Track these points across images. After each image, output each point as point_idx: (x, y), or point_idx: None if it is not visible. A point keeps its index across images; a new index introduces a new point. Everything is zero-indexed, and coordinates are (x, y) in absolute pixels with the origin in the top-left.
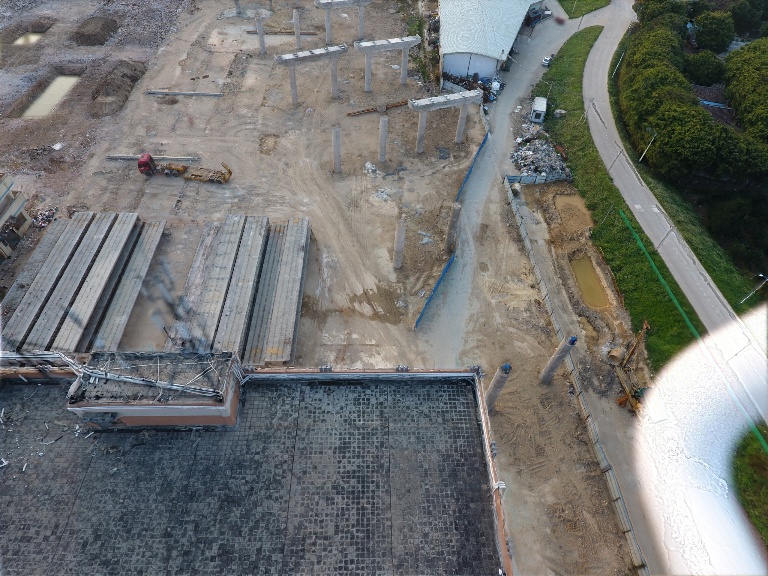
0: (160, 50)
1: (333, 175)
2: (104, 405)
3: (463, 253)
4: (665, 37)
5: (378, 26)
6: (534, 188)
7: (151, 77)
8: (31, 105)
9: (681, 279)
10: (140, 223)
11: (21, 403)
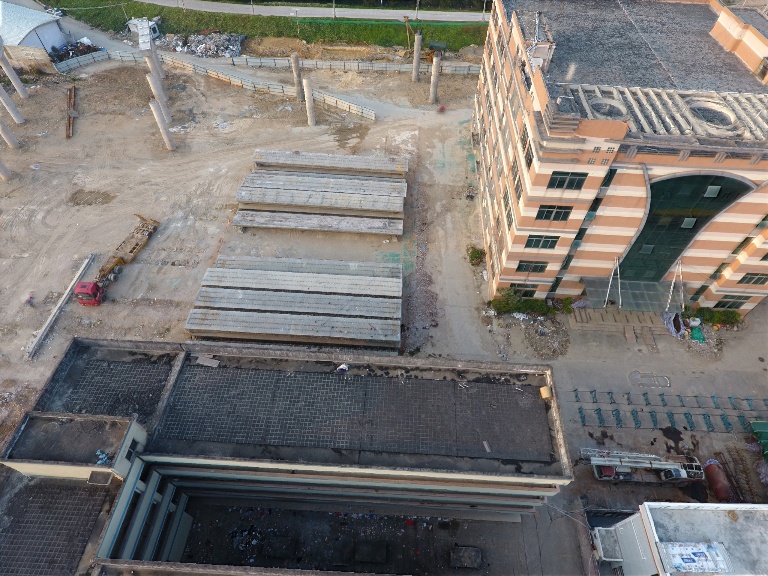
0: None
1: (179, 152)
2: None
3: None
4: None
5: None
6: None
7: None
8: None
9: (358, 17)
10: None
11: None
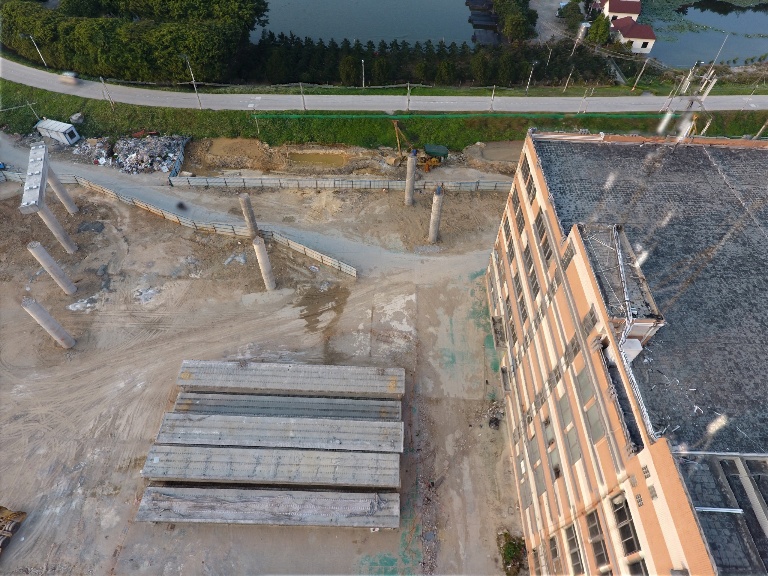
0: None
1: (78, 350)
2: None
3: None
4: (23, 5)
5: None
6: (188, 166)
7: None
8: None
9: (335, 108)
10: None
11: None
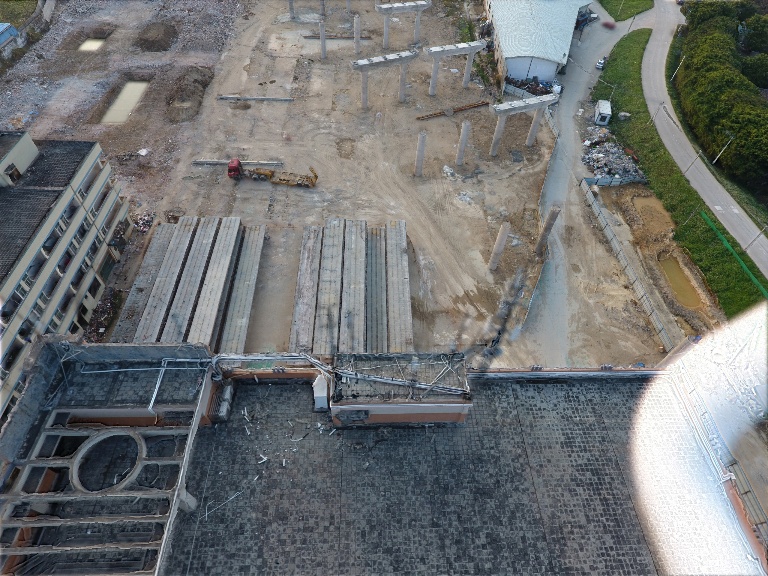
0: (223, 55)
1: (414, 178)
2: (363, 403)
3: (553, 255)
4: (722, 40)
5: (430, 30)
6: (610, 190)
7: (220, 82)
8: (107, 111)
9: None
10: (241, 227)
11: (259, 402)
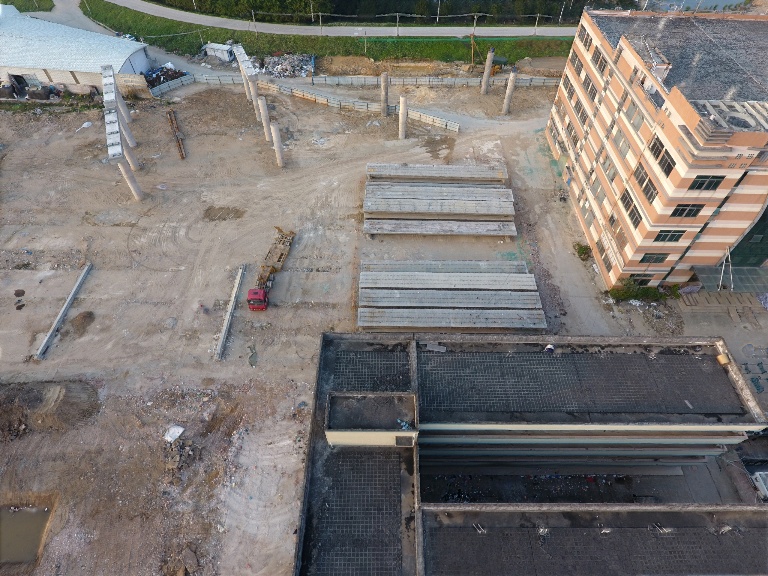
0: None
1: (289, 168)
2: None
3: None
4: None
5: None
6: None
7: None
8: None
9: (418, 34)
10: None
11: None
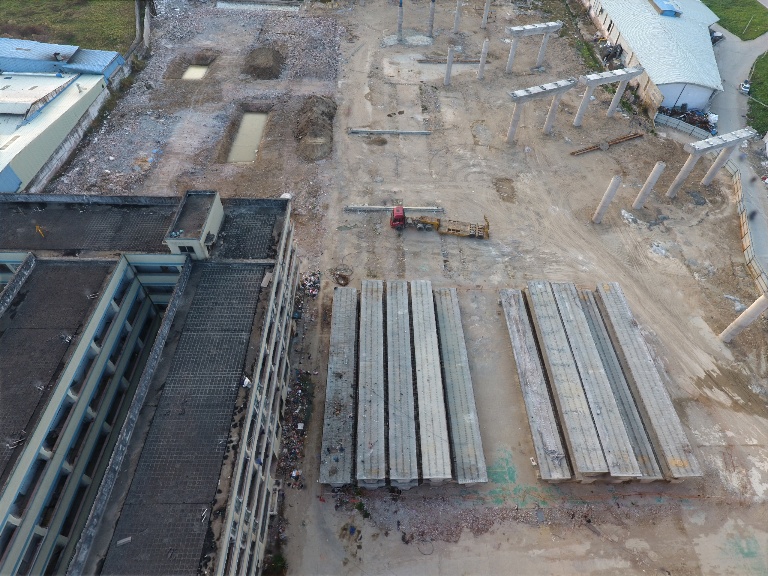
0: (339, 83)
1: (594, 226)
2: None
3: None
4: None
5: (548, 52)
6: None
7: (345, 114)
8: (231, 147)
9: None
10: None
11: None
